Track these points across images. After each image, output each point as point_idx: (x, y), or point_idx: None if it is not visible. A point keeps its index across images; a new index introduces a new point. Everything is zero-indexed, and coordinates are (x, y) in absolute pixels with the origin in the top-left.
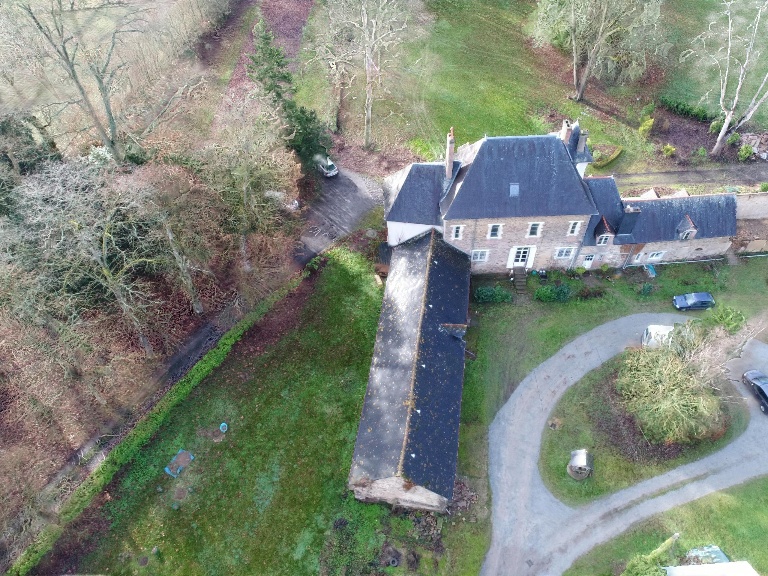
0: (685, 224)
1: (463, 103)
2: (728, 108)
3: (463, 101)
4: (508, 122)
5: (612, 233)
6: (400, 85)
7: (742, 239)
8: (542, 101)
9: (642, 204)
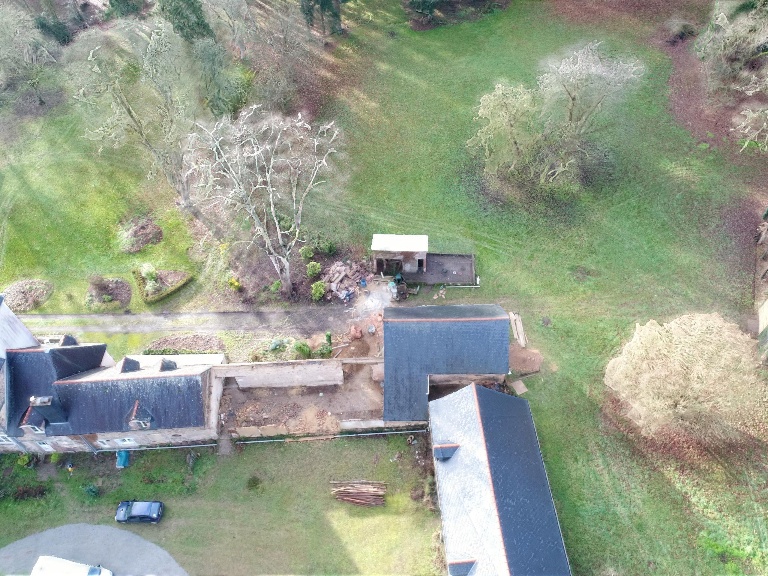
0: (130, 413)
1: (57, 206)
2: (343, 224)
3: (59, 203)
4: (90, 234)
5: (32, 425)
6: (2, 179)
7: (245, 419)
8: (146, 206)
9: (79, 386)
